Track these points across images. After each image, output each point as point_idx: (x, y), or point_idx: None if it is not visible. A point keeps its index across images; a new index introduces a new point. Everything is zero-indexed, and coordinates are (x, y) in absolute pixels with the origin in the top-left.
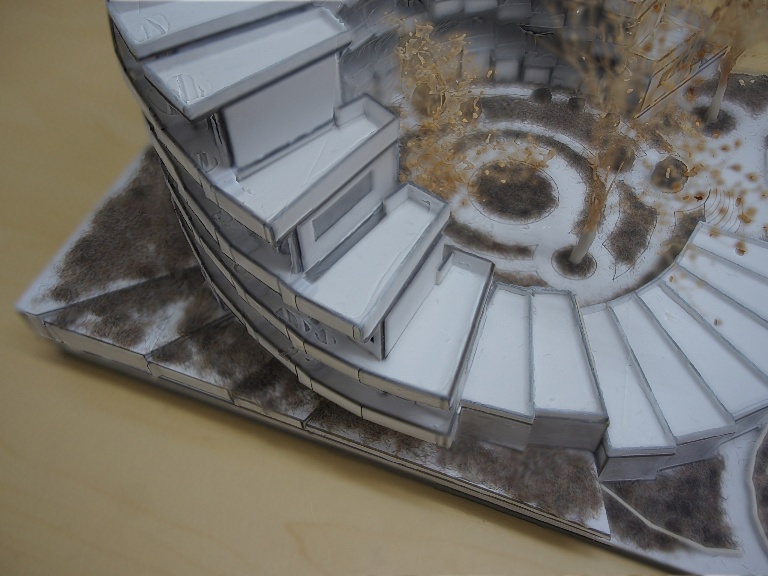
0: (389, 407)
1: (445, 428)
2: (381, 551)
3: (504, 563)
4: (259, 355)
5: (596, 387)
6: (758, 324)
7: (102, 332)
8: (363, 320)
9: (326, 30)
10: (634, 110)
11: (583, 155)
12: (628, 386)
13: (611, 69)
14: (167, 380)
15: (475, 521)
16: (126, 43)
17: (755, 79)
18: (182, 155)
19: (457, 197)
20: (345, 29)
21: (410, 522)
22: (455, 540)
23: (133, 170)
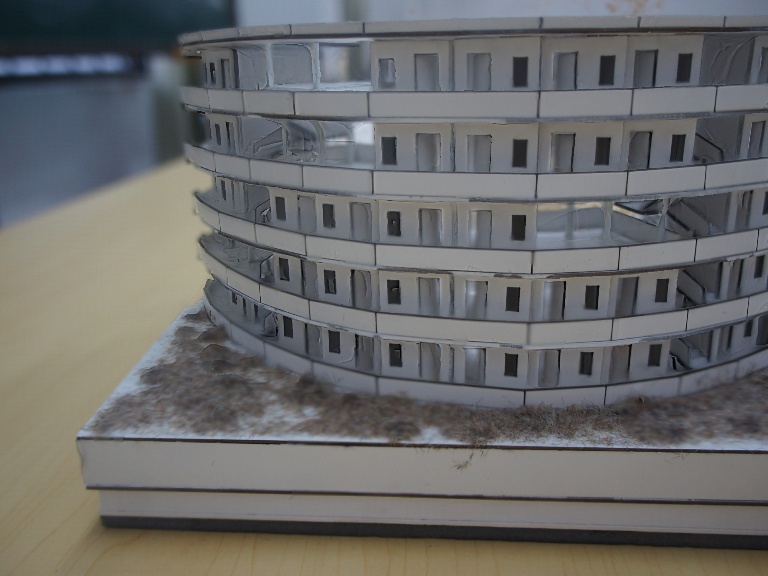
0: None
1: None
2: None
3: None
4: None
5: None
6: None
7: None
8: None
9: None
10: None
11: None
12: None
13: None
14: None
15: None
16: None
17: None
18: None
19: None
20: None
21: None
22: None
23: (720, 444)
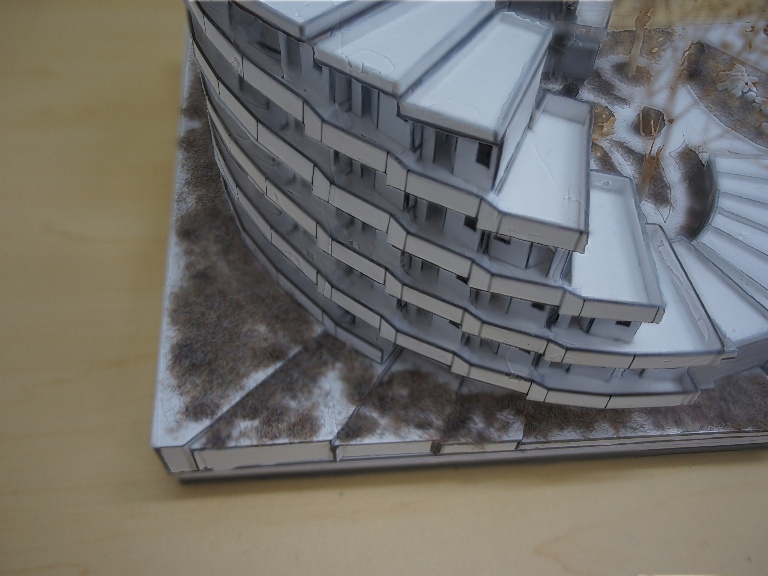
0: (628, 388)
1: (690, 386)
2: (635, 532)
3: (730, 494)
4: (445, 394)
5: (762, 307)
6: None
7: (271, 434)
8: (663, 300)
9: (522, 32)
10: (585, 77)
11: None
12: None
13: (559, 44)
14: (349, 460)
15: (684, 470)
16: (372, 83)
17: None
18: (452, 190)
19: None
20: (546, 27)
21: (638, 495)
22: (681, 494)
23: (175, 256)
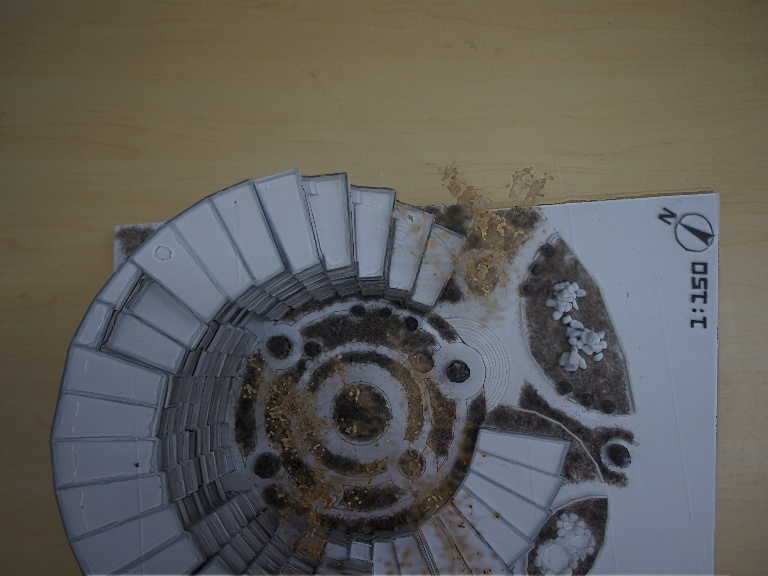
0: None
1: None
2: None
3: None
4: None
5: None
6: (519, 499)
7: None
8: None
9: None
10: None
11: (399, 362)
12: (456, 566)
13: None
14: None
15: None
16: None
17: (508, 217)
18: None
19: None
20: None
21: None
22: None
23: None
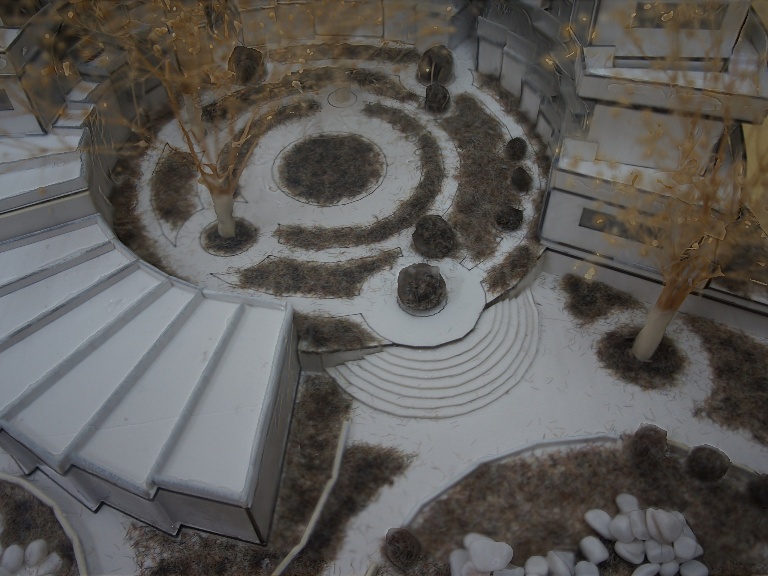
0: None
1: None
2: None
3: None
4: None
5: None
6: None
7: None
8: None
9: None
10: None
11: (431, 210)
12: None
13: None
14: None
15: None
16: None
17: None
18: None
19: (297, 129)
20: None
21: None
22: None
23: None
